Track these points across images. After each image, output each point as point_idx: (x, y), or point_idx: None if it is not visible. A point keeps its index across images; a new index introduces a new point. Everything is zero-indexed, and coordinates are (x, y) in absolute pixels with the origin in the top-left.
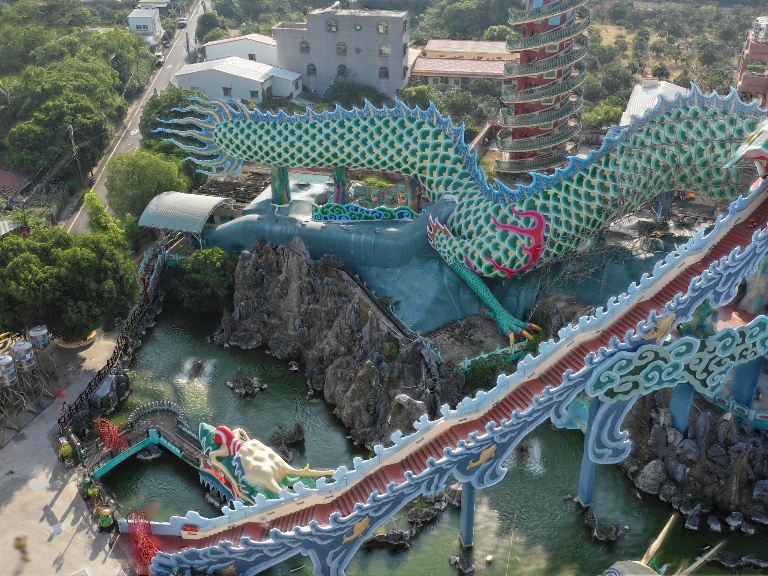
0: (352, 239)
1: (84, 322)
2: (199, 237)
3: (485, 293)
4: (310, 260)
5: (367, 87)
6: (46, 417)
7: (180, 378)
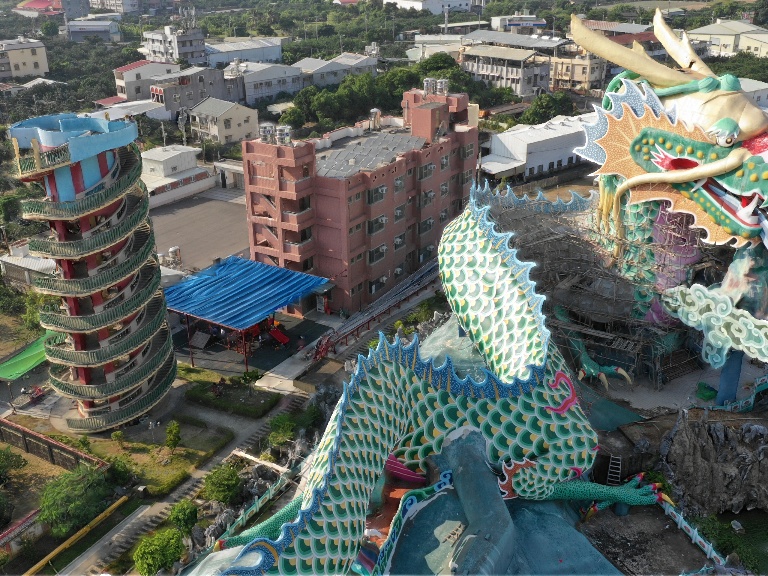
0: (487, 575)
1: None
2: None
3: (598, 488)
4: None
5: None
6: None
7: None
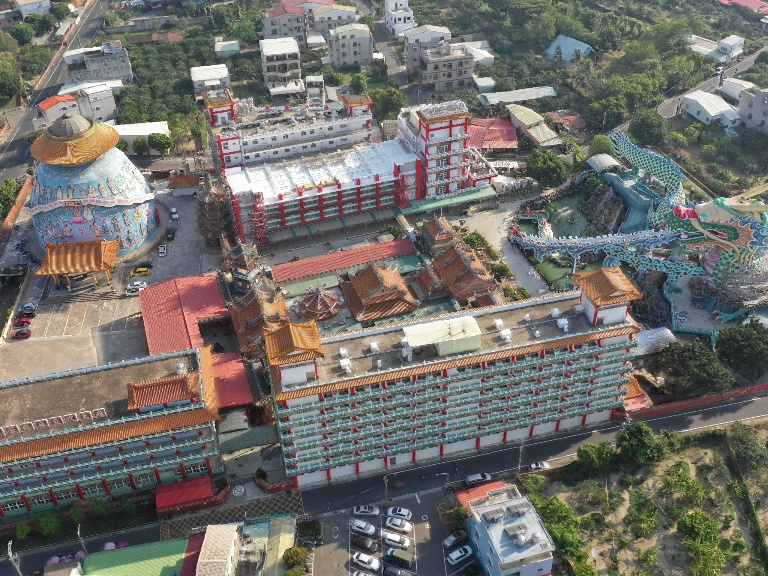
0: (631, 196)
1: (544, 182)
2: (599, 173)
3: None
4: (613, 196)
5: (767, 137)
6: (522, 201)
7: (561, 210)
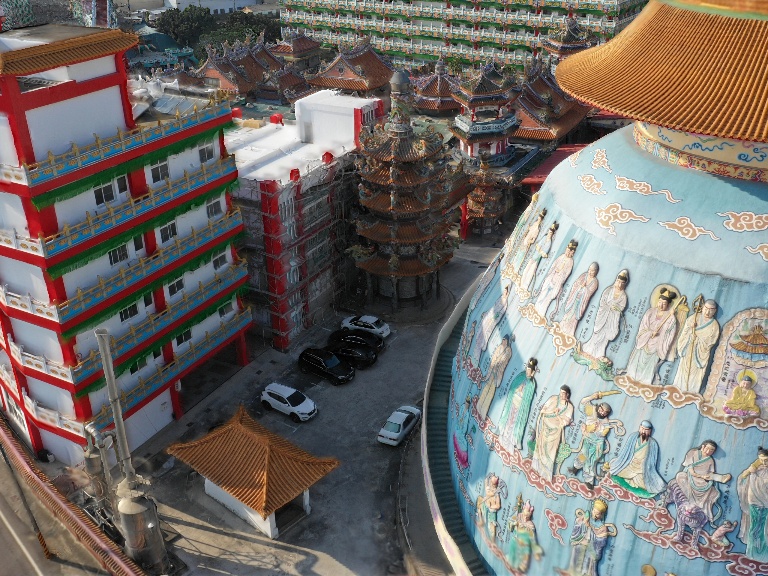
0: None
1: None
2: None
3: None
4: None
5: None
6: None
7: None
